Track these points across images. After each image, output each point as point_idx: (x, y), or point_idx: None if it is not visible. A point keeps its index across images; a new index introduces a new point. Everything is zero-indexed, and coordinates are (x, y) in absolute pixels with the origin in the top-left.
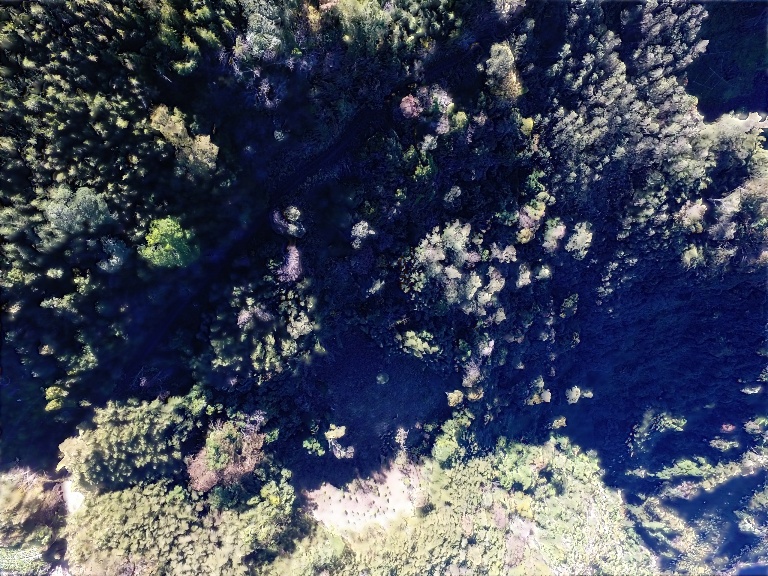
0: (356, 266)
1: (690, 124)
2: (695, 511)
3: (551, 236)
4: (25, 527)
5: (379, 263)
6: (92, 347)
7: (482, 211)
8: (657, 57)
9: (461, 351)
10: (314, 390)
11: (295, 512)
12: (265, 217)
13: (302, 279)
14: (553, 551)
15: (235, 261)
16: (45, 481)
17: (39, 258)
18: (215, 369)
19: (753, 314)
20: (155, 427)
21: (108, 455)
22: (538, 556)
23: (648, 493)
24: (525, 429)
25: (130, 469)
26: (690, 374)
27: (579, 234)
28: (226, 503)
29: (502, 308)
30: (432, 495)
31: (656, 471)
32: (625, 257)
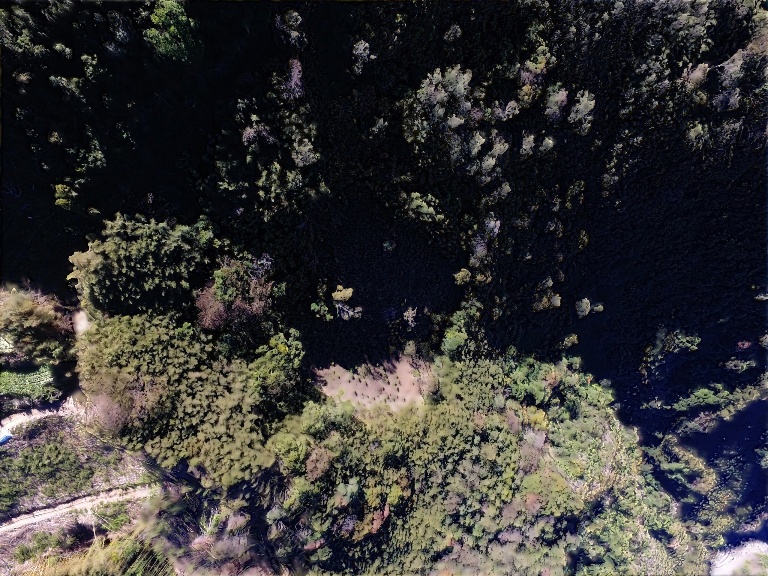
0: (359, 100)
1: None
2: (715, 449)
3: (553, 101)
4: (36, 336)
5: (382, 105)
6: (100, 144)
7: (483, 63)
8: None
9: (467, 225)
10: (321, 257)
11: (304, 383)
12: (268, 33)
13: (305, 104)
14: (569, 467)
15: (239, 77)
16: (56, 305)
17: (48, 29)
18: (221, 192)
19: (763, 206)
20: (163, 248)
21: (117, 270)
22: (553, 468)
23: (665, 431)
24: (536, 347)
25: (139, 292)
26: (702, 286)
27: (581, 102)
28: (235, 351)
29: (507, 182)
30: (443, 388)
31: (672, 403)
32: (629, 137)
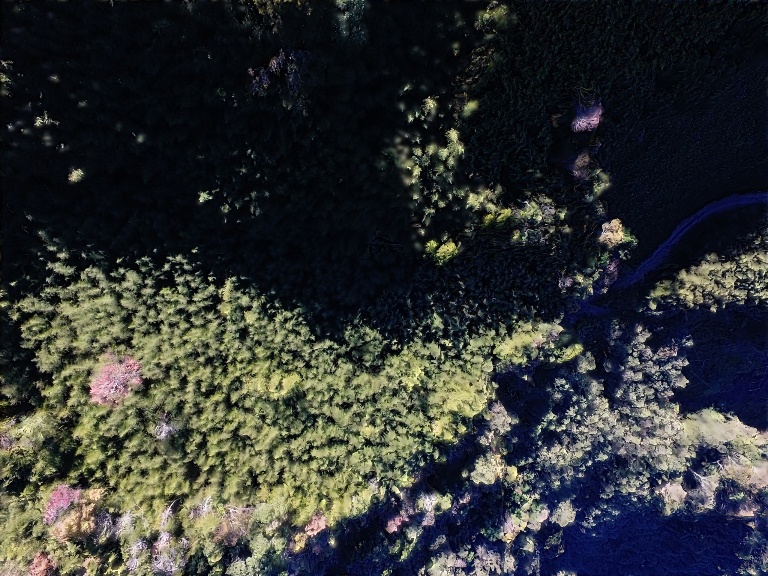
0: None
1: (671, 434)
2: None
3: (535, 520)
4: None
5: None
6: None
7: (467, 529)
8: (639, 394)
9: None
10: None
11: None
12: None
13: None
14: None
15: None
16: None
17: None
18: None
19: (732, 530)
20: None
21: None
22: None
23: None
24: None
25: None
26: (671, 554)
27: (563, 511)
28: None
29: None
30: None
31: None
32: (608, 506)
